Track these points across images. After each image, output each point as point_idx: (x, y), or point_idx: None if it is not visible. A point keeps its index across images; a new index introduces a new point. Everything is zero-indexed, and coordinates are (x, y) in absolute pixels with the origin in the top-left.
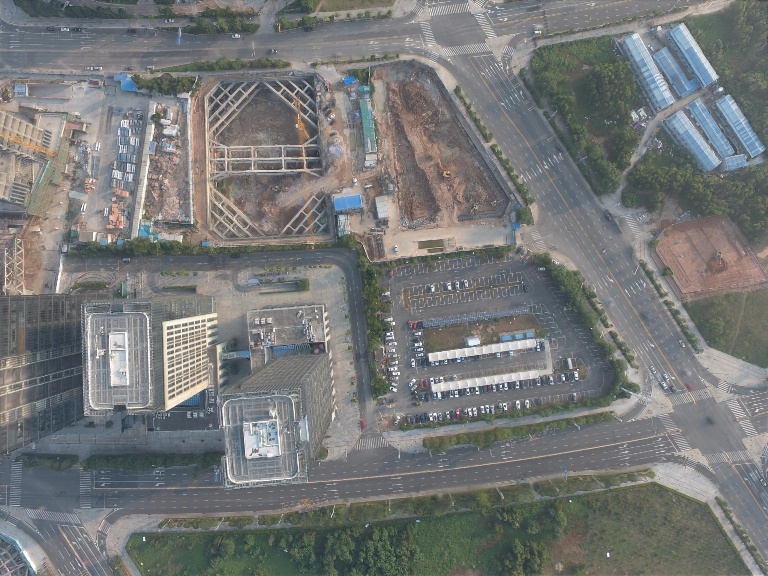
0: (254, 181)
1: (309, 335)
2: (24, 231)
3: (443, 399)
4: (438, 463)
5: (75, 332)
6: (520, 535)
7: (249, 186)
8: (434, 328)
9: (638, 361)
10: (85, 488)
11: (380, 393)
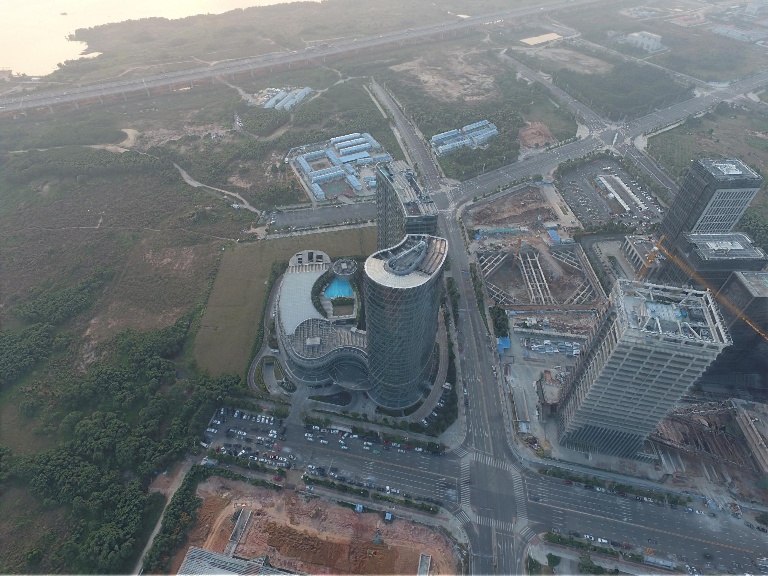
0: None
1: None
2: None
3: None
4: None
5: None
6: None
7: None
8: None
9: None
10: None
11: None
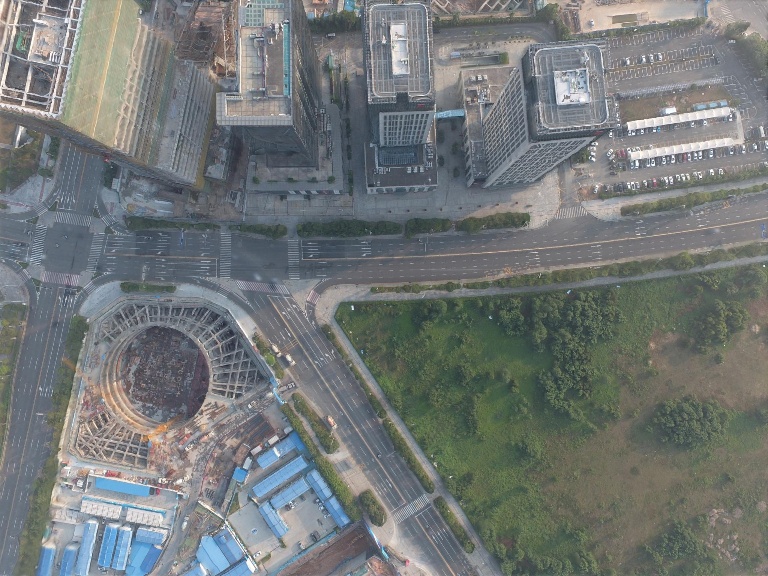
0: None
1: None
2: (235, 4)
3: (640, 168)
4: (635, 231)
5: (312, 73)
6: None
7: None
8: (629, 100)
9: None
10: (293, 259)
11: (583, 158)
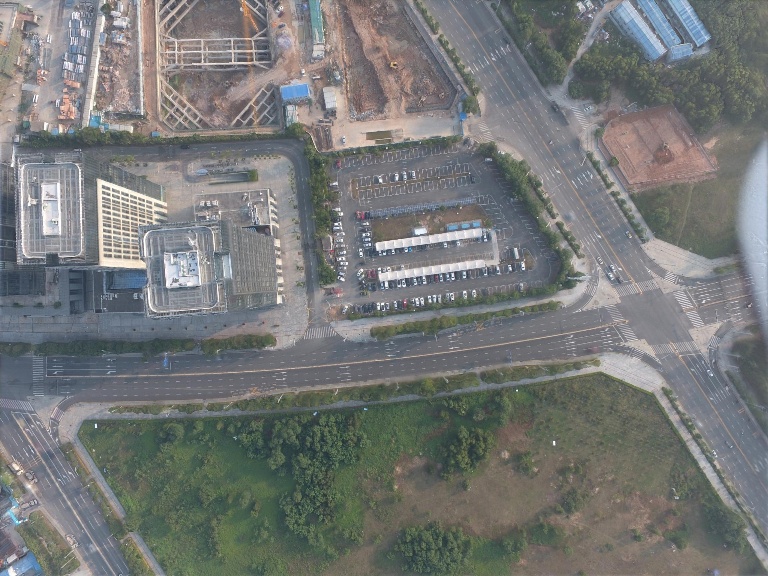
0: (207, 79)
1: (254, 218)
2: None
3: (391, 289)
4: (386, 352)
5: None
6: (467, 423)
7: (202, 84)
8: (382, 219)
9: (585, 252)
10: (38, 376)
11: (327, 280)
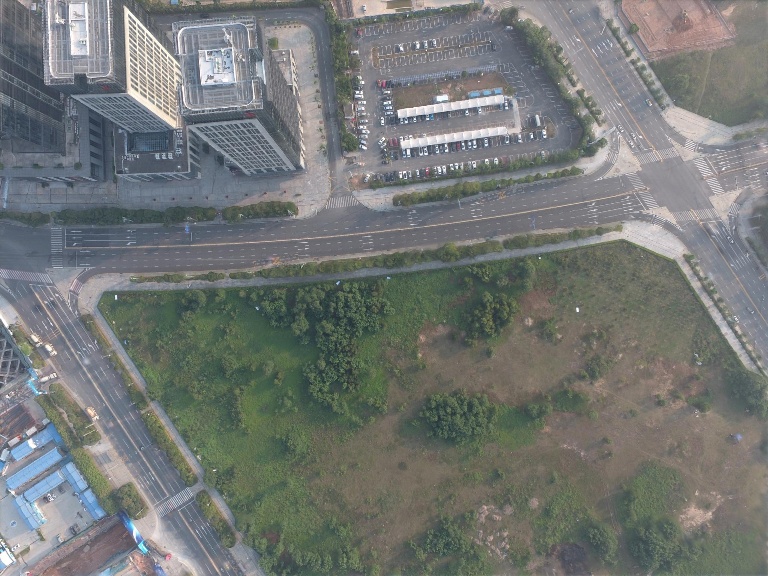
0: None
1: None
2: None
3: (412, 157)
4: (408, 221)
5: (41, 56)
6: (490, 291)
7: None
8: (403, 87)
9: (606, 120)
10: (57, 248)
11: (349, 146)
